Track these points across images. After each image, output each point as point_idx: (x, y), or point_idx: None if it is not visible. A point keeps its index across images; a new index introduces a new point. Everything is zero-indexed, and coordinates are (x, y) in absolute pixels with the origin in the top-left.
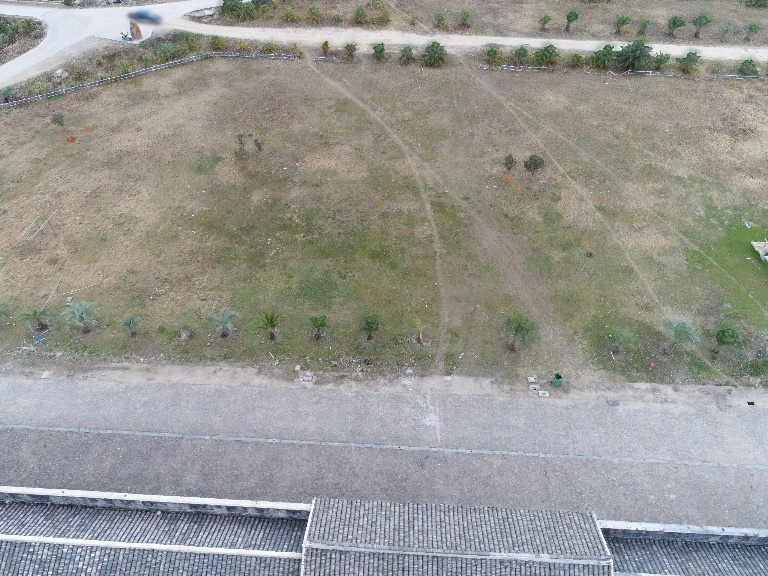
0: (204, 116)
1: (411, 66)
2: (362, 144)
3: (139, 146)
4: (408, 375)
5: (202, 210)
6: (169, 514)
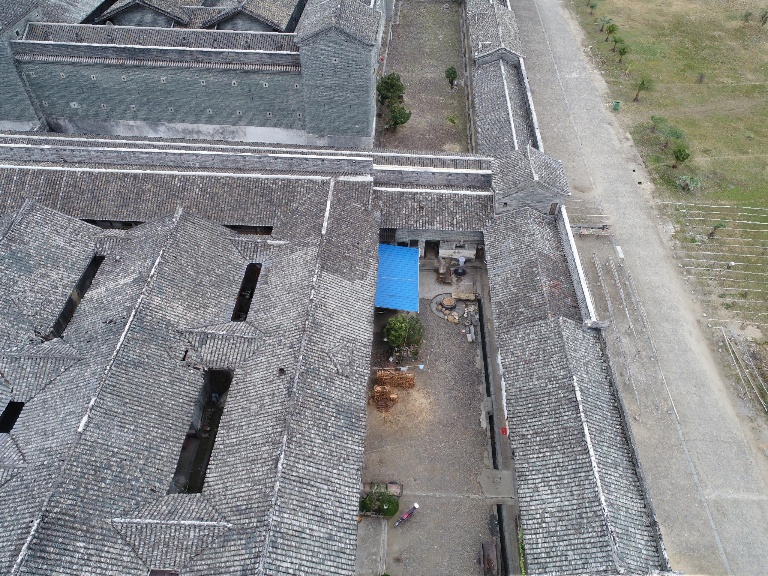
0: None
1: None
2: None
3: (738, 1)
4: (600, 71)
5: (691, 20)
6: (503, 2)
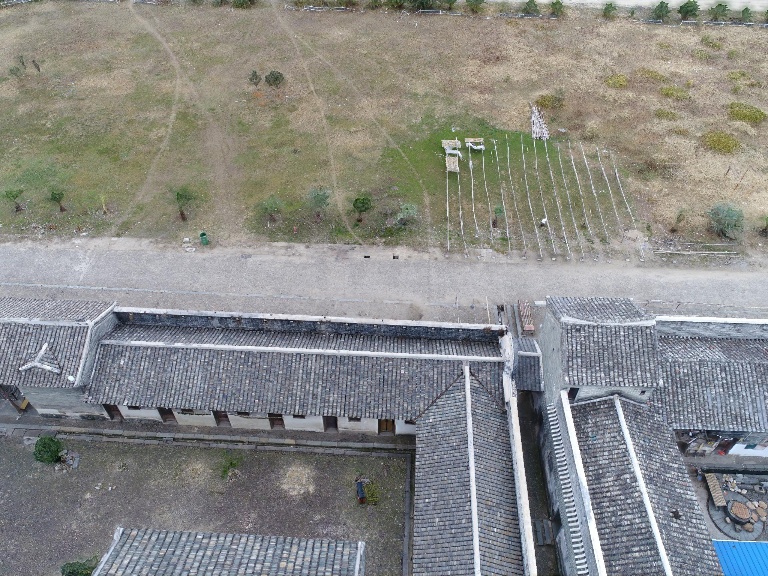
0: (9, 46)
1: (223, 7)
2: (141, 68)
3: None
4: (81, 236)
5: None
6: None
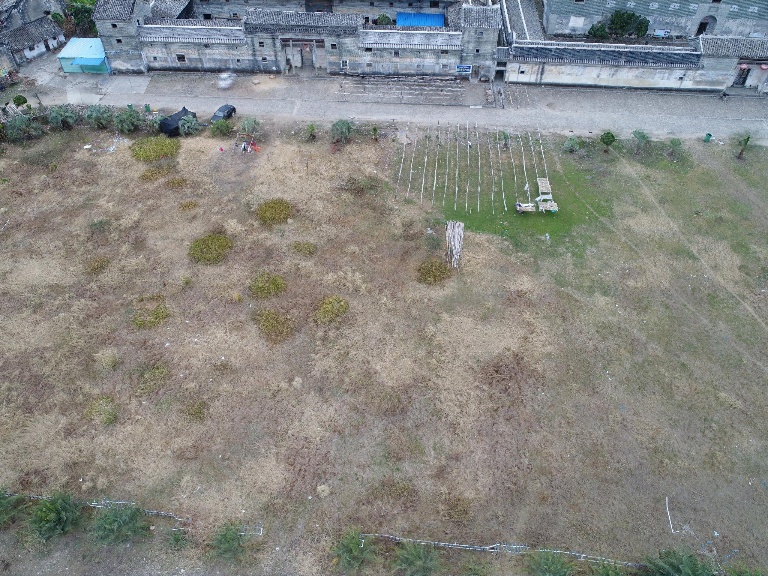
0: None
1: None
2: None
3: None
4: None
5: None
6: None
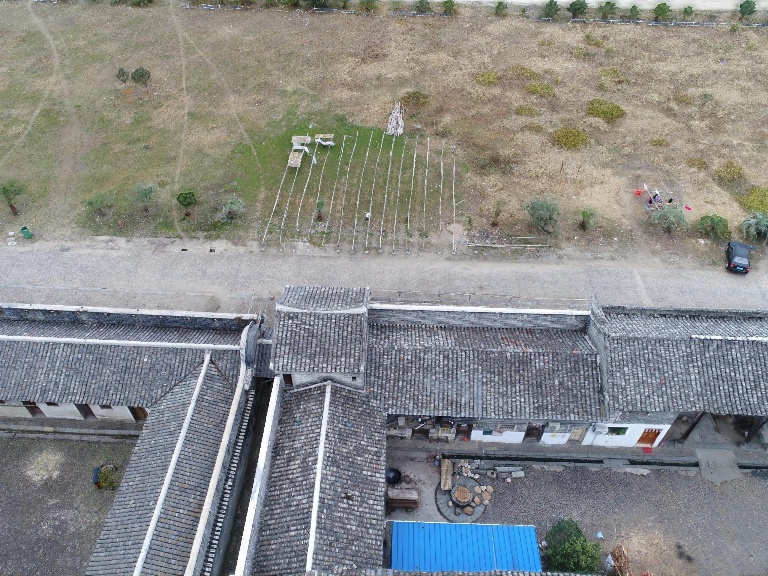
0: None
1: (121, 6)
2: (20, 66)
3: None
4: None
5: None
6: None
